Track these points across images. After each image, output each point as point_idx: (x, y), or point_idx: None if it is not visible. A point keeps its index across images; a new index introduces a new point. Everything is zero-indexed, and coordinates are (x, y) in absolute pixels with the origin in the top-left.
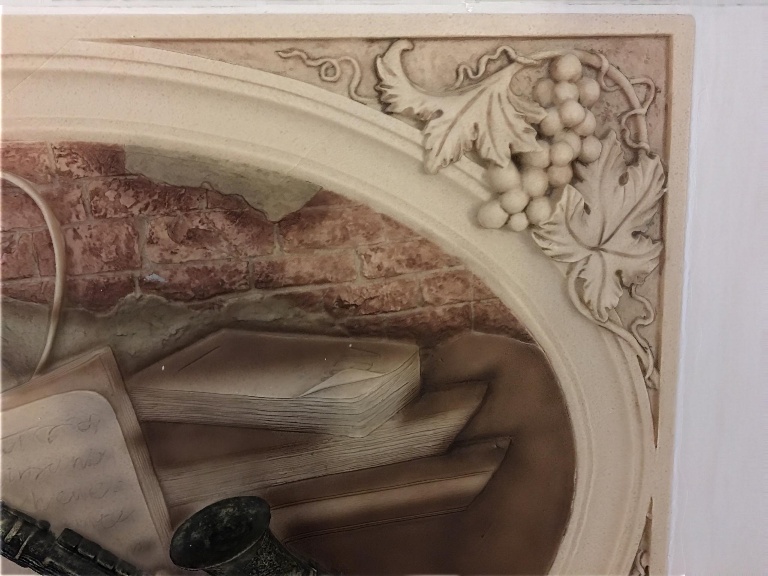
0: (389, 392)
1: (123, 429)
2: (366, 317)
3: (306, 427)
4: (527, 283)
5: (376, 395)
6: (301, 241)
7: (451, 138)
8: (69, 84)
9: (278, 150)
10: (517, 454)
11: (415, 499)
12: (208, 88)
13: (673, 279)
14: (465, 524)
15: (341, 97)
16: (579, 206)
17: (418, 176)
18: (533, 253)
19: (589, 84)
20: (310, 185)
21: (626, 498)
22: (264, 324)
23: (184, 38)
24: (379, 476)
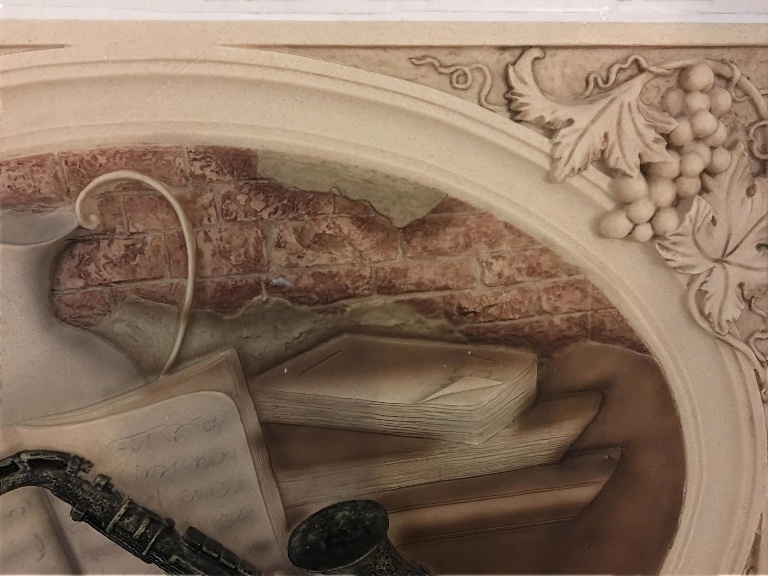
0: (507, 400)
1: (246, 430)
2: (484, 324)
3: (423, 433)
4: (645, 294)
5: (494, 403)
6: (424, 247)
7: (581, 147)
8: (207, 89)
9: (406, 156)
10: (628, 465)
11: (526, 508)
12: (342, 94)
13: None
14: (572, 534)
15: (472, 105)
16: (707, 217)
17: (542, 184)
18: (653, 264)
19: (721, 94)
20: (436, 192)
21: (735, 513)
22: (385, 329)
23: (322, 44)
24: (492, 484)
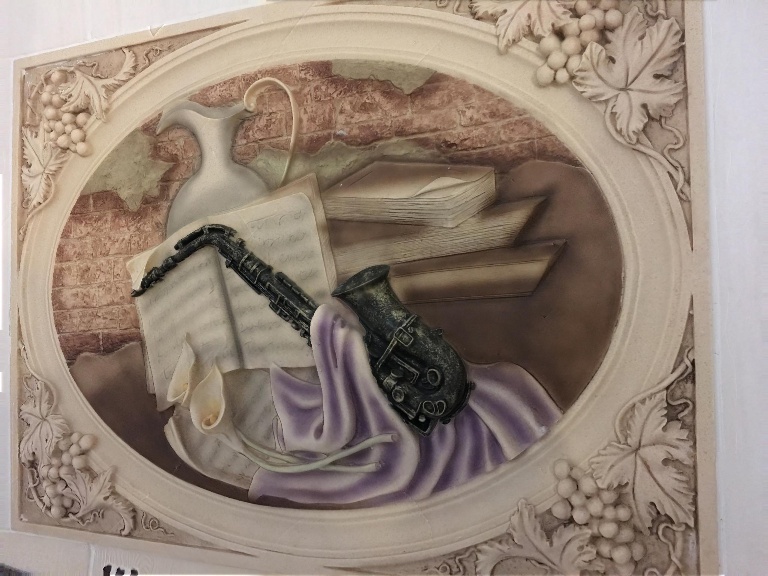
0: (471, 197)
1: (316, 219)
2: (462, 152)
3: (418, 221)
4: (577, 124)
5: (461, 197)
6: (423, 105)
7: (512, 25)
8: (309, 32)
9: (412, 52)
10: (572, 253)
11: (491, 279)
12: (375, 21)
13: (696, 109)
14: (532, 307)
15: (446, 13)
16: (601, 55)
17: (497, 58)
18: (580, 101)
19: None
20: (429, 70)
21: (669, 296)
22: (398, 157)
23: None
24: (465, 260)
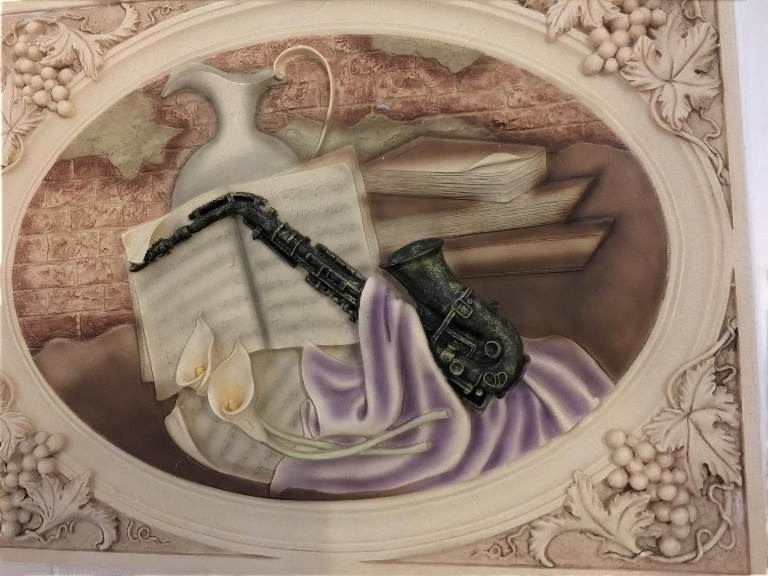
0: (525, 173)
1: (357, 192)
2: (510, 132)
3: (469, 195)
4: (622, 111)
5: (516, 173)
6: (470, 85)
7: (564, 15)
8: (347, 5)
9: (458, 34)
10: (620, 230)
11: (544, 254)
12: (420, 1)
13: (732, 103)
14: (582, 282)
15: None
16: (651, 48)
17: (544, 45)
18: (625, 90)
19: None
20: (476, 52)
21: (712, 270)
22: (445, 134)
23: None
24: (518, 235)
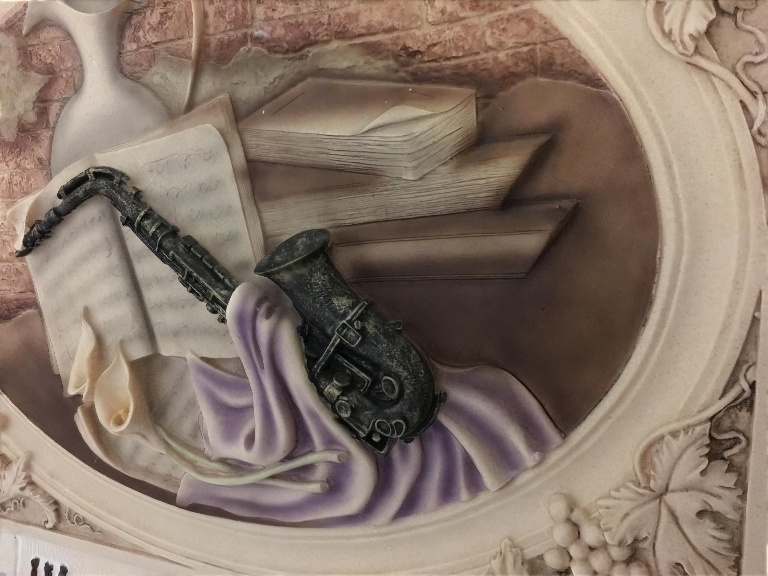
0: (441, 135)
1: (233, 162)
2: (430, 65)
3: (368, 168)
4: (602, 20)
5: (427, 136)
6: None
7: None
8: None
9: None
10: (585, 220)
11: (469, 254)
12: None
13: None
14: (526, 294)
15: None
16: None
17: None
18: None
19: None
20: None
21: (726, 289)
22: (340, 72)
23: None
24: (434, 225)
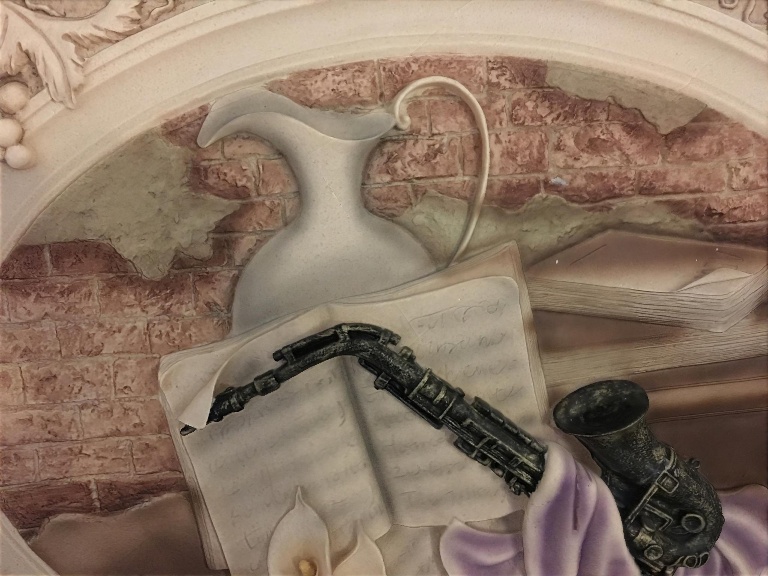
0: (749, 292)
1: (522, 314)
2: (728, 225)
3: (674, 321)
4: None
5: (740, 294)
6: (683, 153)
7: None
8: (508, 5)
9: (673, 70)
10: None
11: (753, 393)
12: (626, 11)
13: None
14: None
15: (740, 22)
16: None
17: None
18: None
19: None
20: (698, 102)
21: None
22: (644, 227)
23: None
24: (727, 370)
